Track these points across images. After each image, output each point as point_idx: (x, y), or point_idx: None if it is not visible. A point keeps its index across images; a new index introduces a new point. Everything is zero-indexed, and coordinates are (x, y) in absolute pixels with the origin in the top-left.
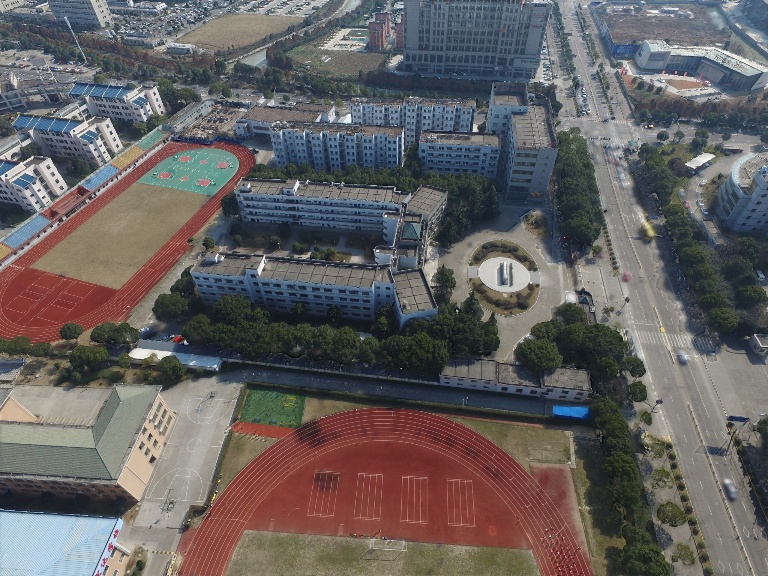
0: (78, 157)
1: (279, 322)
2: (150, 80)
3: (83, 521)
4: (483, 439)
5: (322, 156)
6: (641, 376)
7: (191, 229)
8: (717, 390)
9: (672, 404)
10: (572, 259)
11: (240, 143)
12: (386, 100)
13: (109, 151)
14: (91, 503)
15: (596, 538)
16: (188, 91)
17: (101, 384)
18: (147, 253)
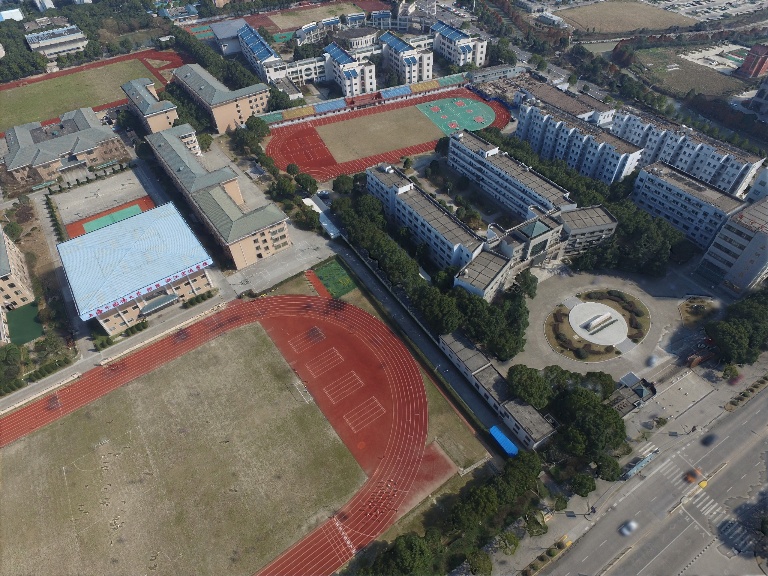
0: (395, 73)
1: (392, 236)
2: (501, 37)
3: (200, 248)
4: (424, 400)
5: (551, 144)
6: (604, 479)
7: (411, 151)
8: (685, 572)
9: (614, 530)
10: (687, 359)
11: (510, 109)
12: (659, 120)
13: (420, 78)
14: (222, 254)
15: (415, 519)
16: (510, 53)
17: (280, 206)
18: (373, 152)
